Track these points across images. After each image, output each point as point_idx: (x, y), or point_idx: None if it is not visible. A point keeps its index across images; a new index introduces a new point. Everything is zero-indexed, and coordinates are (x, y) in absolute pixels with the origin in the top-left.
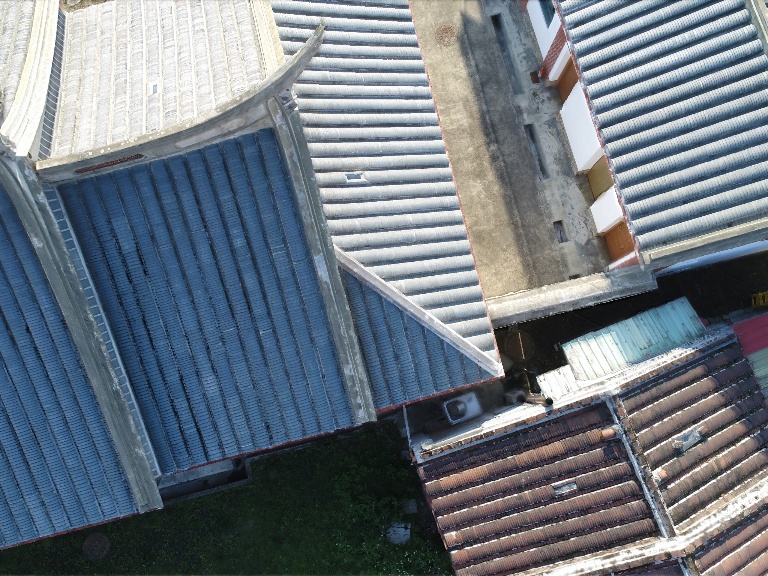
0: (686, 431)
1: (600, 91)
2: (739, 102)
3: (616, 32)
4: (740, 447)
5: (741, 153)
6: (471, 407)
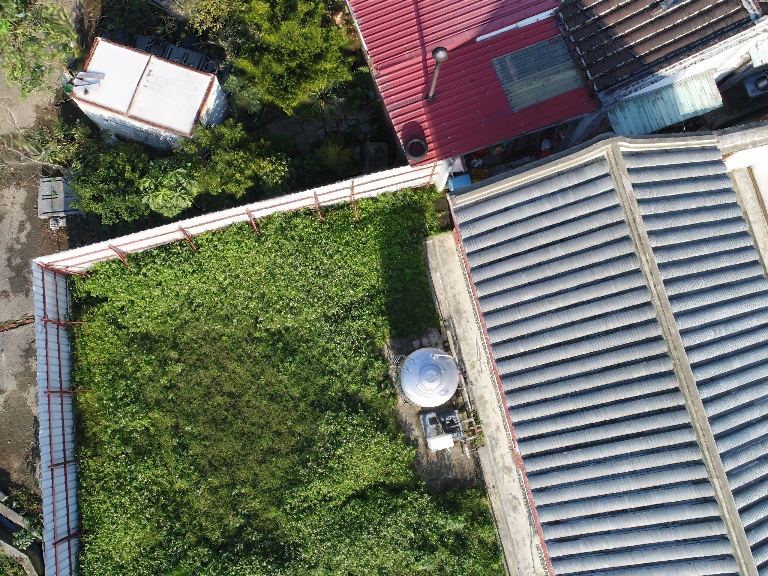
0: (675, 7)
1: (767, 296)
2: (677, 255)
3: (766, 352)
4: (615, 5)
5: (670, 208)
6: (752, 85)
